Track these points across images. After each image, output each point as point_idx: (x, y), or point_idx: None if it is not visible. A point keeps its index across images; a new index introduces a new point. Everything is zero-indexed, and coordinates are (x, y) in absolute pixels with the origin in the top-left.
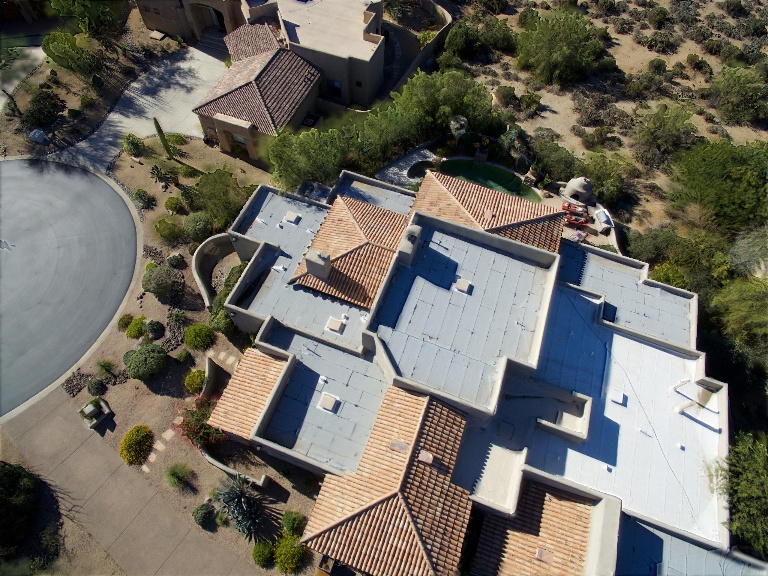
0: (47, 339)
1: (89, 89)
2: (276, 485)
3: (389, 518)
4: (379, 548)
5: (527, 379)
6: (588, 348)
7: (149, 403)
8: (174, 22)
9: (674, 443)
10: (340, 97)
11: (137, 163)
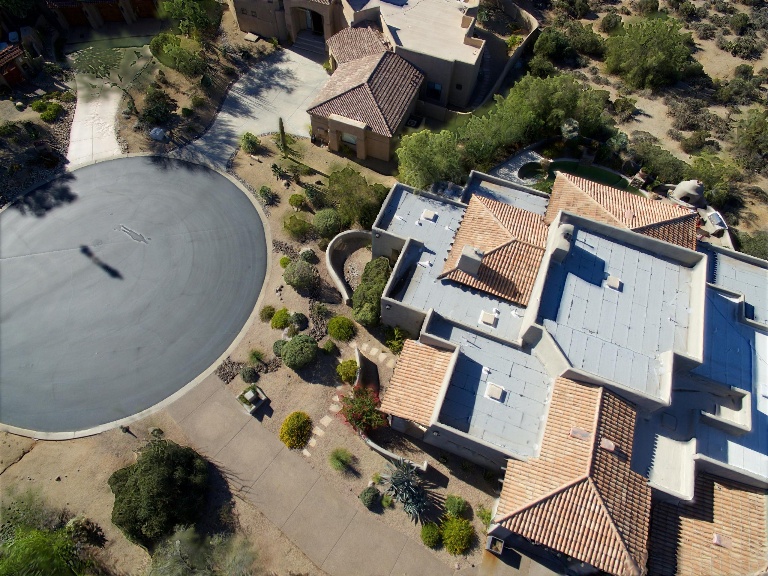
0: (194, 328)
1: (197, 89)
2: (434, 471)
3: (580, 501)
4: (572, 529)
5: (685, 373)
6: (733, 345)
7: (303, 391)
8: (270, 25)
9: None
10: (438, 99)
11: (256, 161)
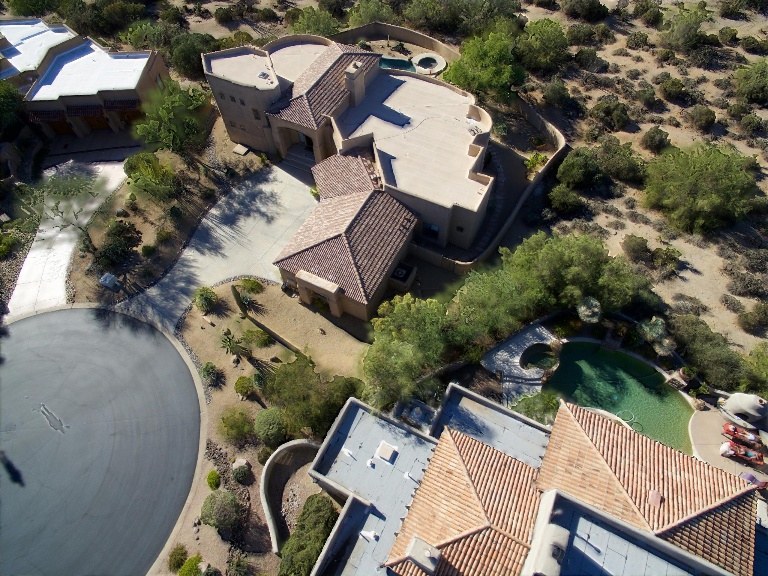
0: (89, 570)
1: (166, 219)
2: None
3: None
4: None
5: None
6: None
7: None
8: (259, 139)
9: None
10: (436, 239)
11: (208, 323)
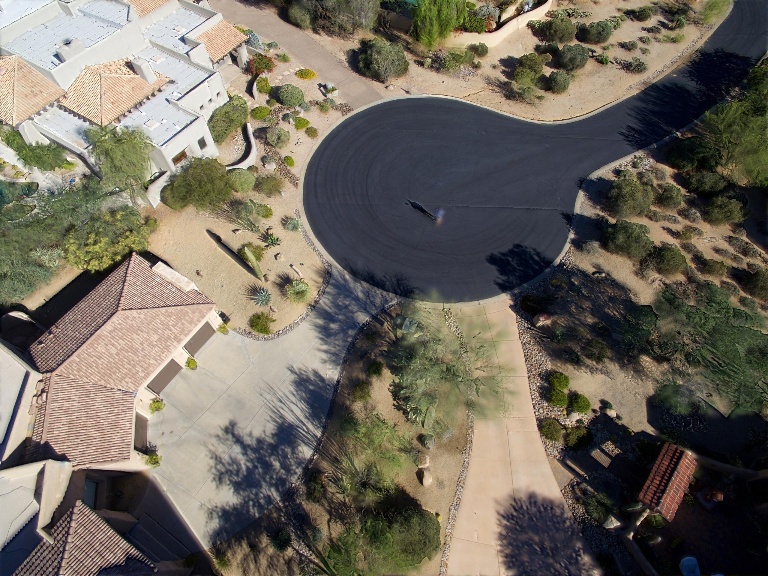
0: (367, 134)
1: None
2: None
3: None
4: None
5: None
6: None
7: None
8: None
9: (23, 5)
10: None
11: None
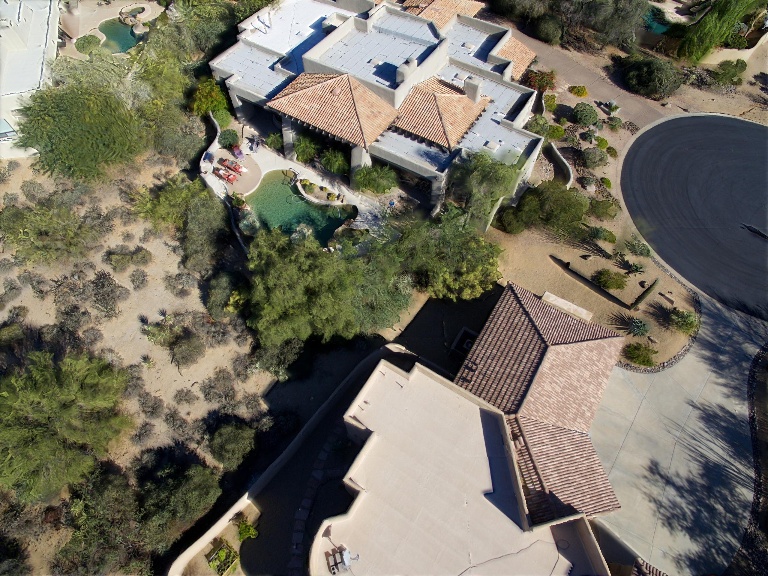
0: (666, 154)
1: None
2: None
3: None
4: None
5: None
6: (304, 52)
7: None
8: None
9: None
10: None
11: None
